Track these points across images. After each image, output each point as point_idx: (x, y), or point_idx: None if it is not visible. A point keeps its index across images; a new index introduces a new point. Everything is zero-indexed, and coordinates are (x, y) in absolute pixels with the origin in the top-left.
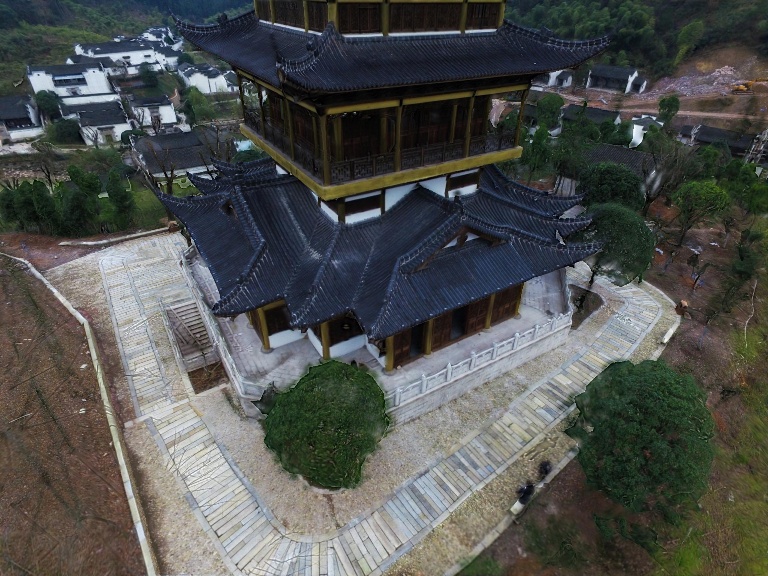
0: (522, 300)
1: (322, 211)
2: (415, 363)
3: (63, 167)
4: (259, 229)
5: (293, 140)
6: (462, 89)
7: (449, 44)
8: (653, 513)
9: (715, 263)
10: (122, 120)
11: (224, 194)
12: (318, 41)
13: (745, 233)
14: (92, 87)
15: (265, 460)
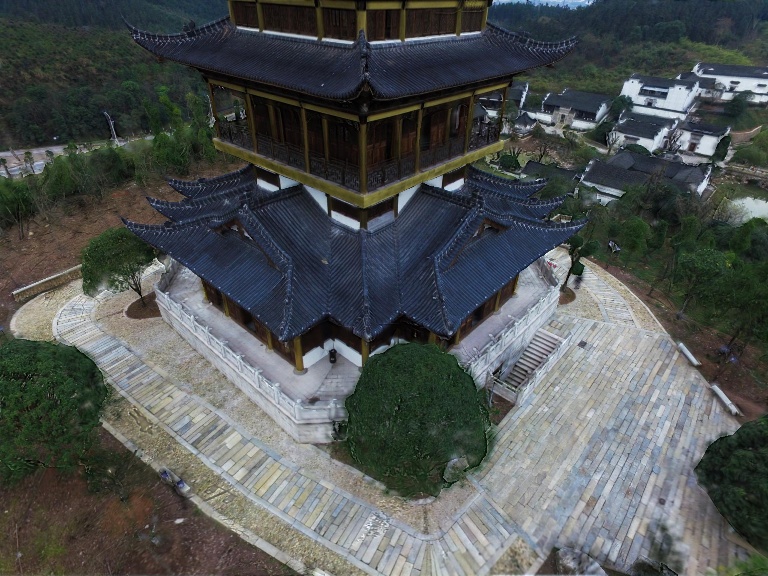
0: (334, 375)
1: None
2: (217, 311)
3: (573, 157)
4: None
5: None
6: (286, 95)
7: (299, 48)
8: (45, 510)
9: None
10: (651, 136)
11: None
12: (197, 26)
13: None
14: (669, 102)
15: (155, 282)
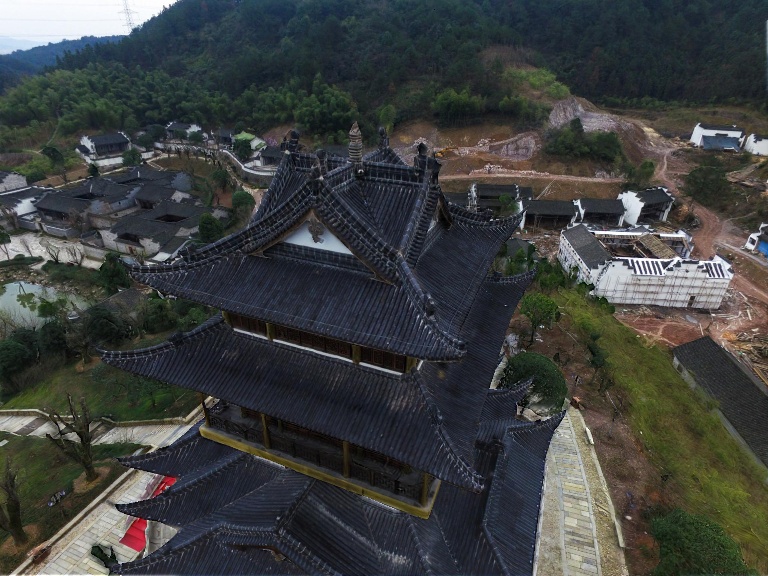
0: None
1: (365, 499)
2: None
3: None
4: (332, 568)
5: (350, 461)
6: None
7: None
8: None
9: (557, 346)
10: None
11: (222, 526)
12: None
13: (558, 314)
14: None
15: None
